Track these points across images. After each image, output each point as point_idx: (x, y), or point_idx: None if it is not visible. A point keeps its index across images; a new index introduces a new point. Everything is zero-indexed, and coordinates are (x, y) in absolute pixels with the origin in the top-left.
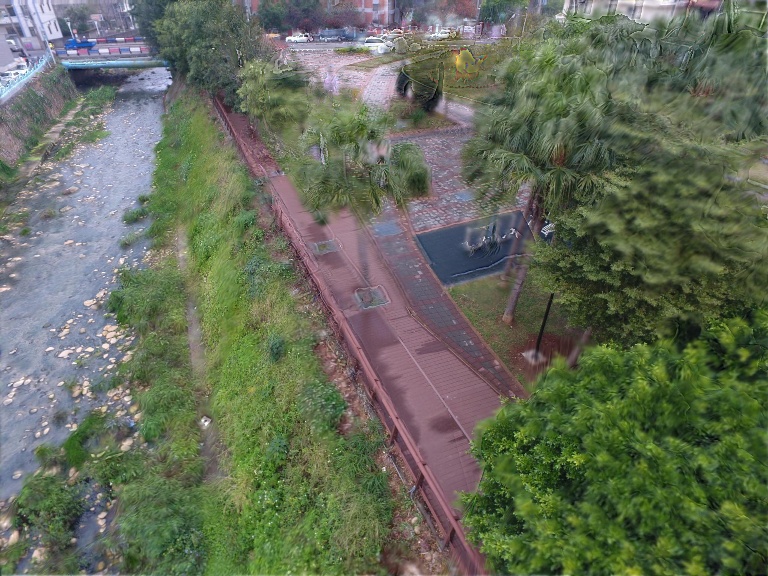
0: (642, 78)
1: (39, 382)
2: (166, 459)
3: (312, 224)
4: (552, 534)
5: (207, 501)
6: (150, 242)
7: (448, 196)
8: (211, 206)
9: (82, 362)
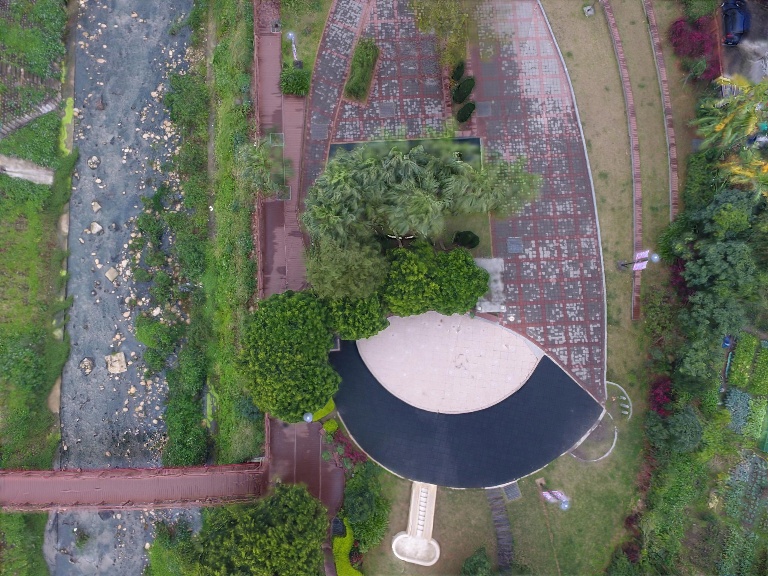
0: (379, 195)
1: (136, 153)
2: (193, 224)
3: (275, 112)
4: (255, 333)
5: (207, 249)
6: (188, 39)
7: (372, 107)
8: (228, 26)
9: (155, 148)
